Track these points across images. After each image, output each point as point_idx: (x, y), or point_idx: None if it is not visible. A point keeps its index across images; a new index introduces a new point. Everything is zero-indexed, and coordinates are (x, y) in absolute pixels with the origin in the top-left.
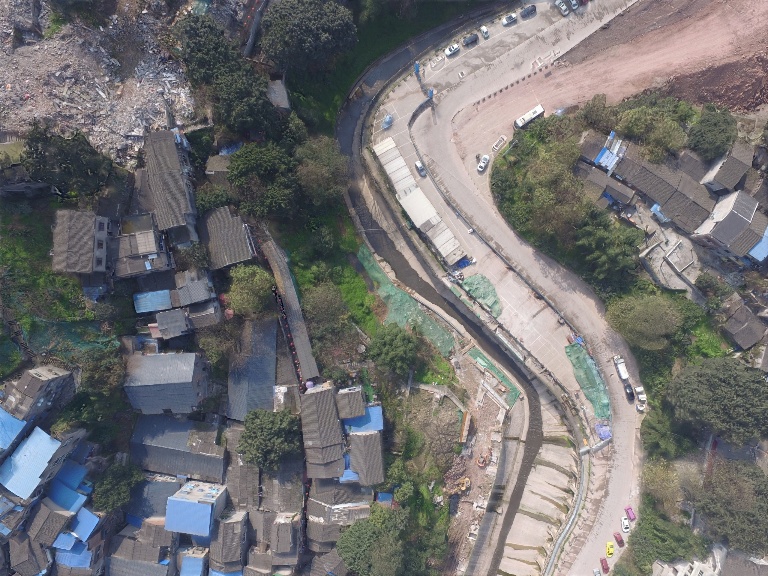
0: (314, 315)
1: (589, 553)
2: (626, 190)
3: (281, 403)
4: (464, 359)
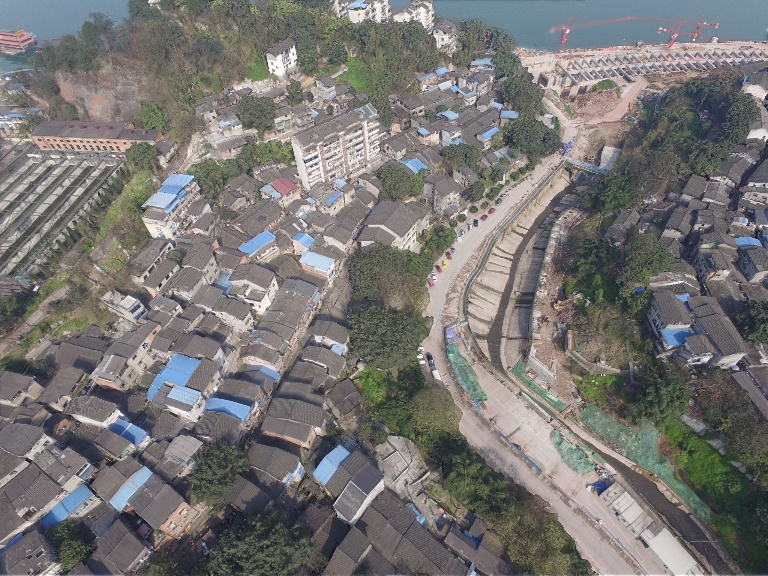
0: (765, 423)
1: (459, 263)
2: (455, 543)
3: (760, 351)
4: (569, 401)
